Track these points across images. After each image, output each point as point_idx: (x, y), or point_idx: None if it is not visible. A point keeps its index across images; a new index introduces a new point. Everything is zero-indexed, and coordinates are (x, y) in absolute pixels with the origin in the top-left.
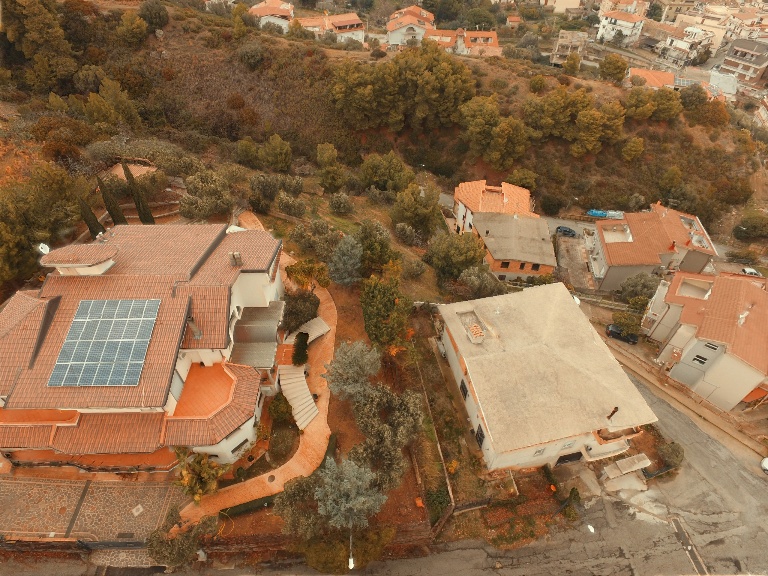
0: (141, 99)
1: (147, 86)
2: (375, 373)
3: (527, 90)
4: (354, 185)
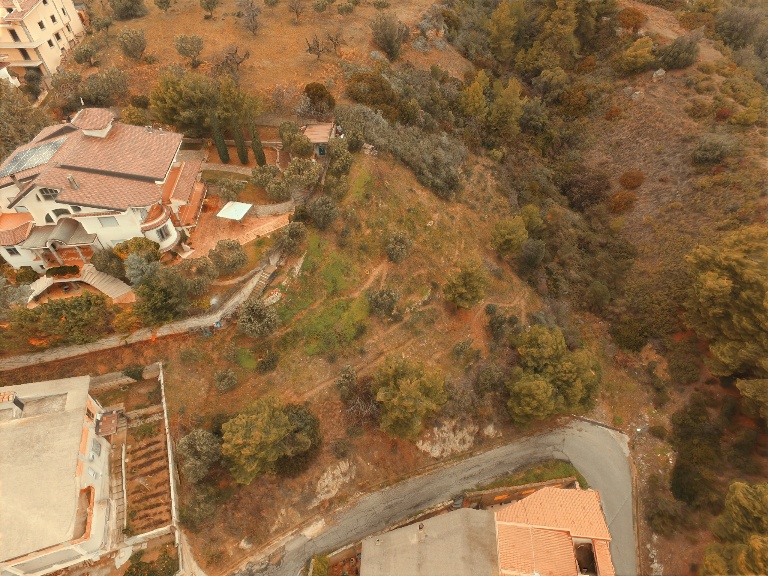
0: (558, 118)
1: (584, 112)
2: None
3: None
4: (493, 327)
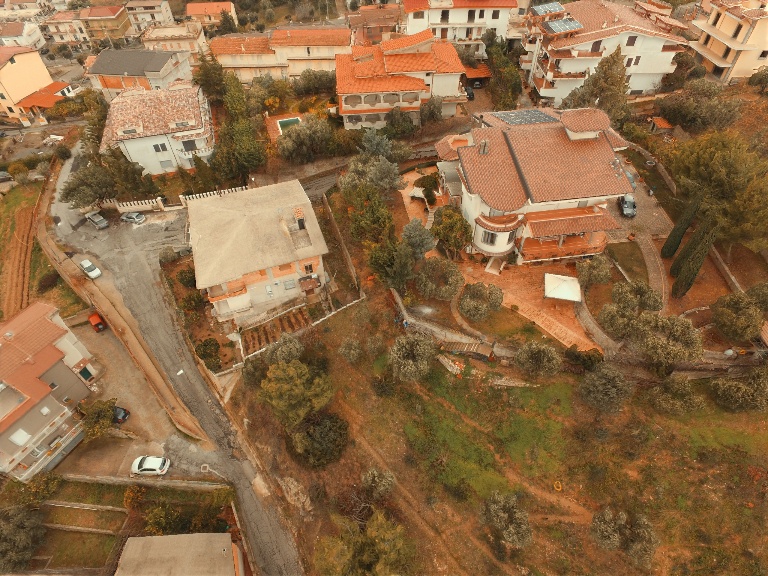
0: None
1: None
2: (372, 183)
3: None
4: None
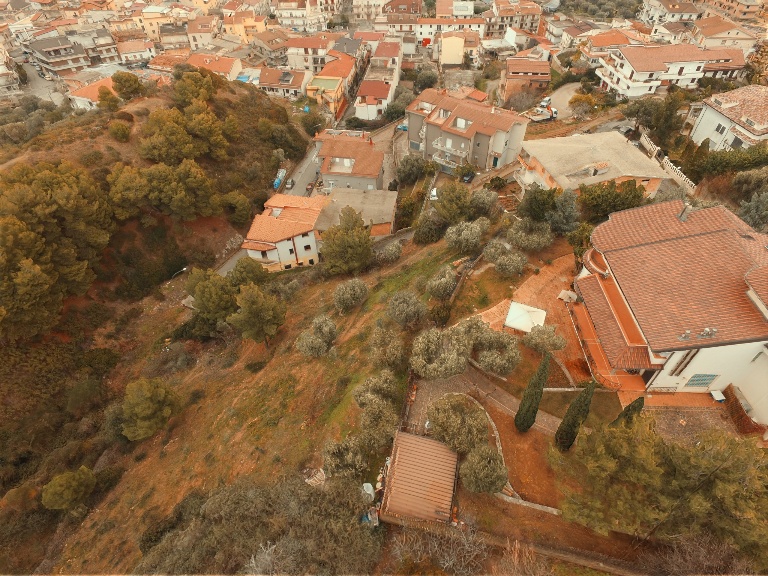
0: None
1: None
2: None
3: (119, 144)
4: None
